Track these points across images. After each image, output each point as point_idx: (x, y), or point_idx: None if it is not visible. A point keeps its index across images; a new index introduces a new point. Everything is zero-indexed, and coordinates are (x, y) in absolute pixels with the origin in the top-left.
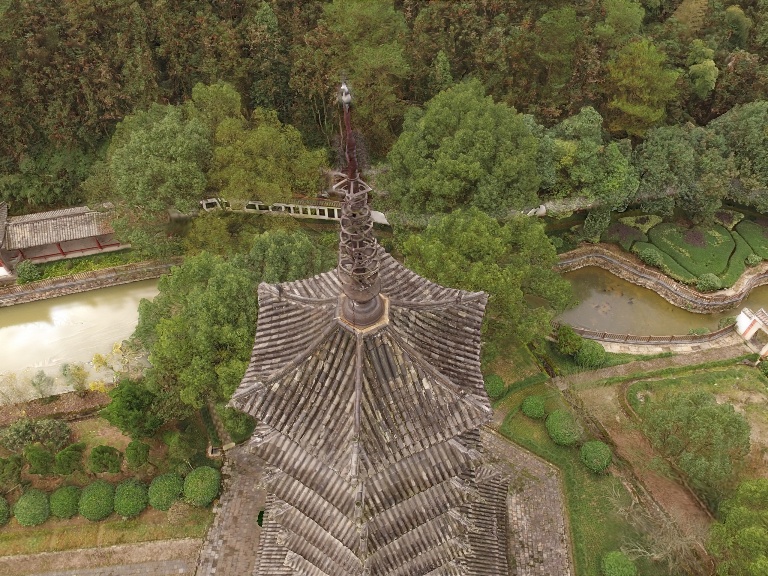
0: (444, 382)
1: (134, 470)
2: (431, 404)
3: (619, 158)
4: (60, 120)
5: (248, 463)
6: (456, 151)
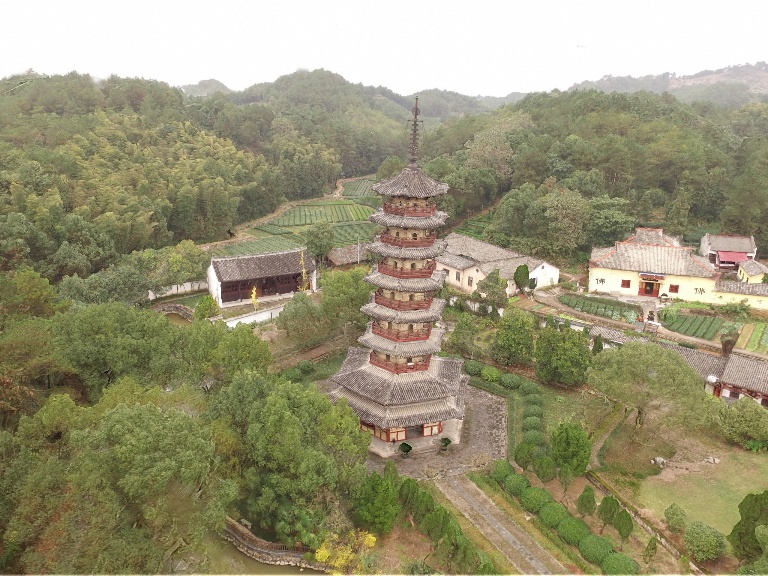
0: None
1: None
2: None
3: None
4: None
5: None
6: None
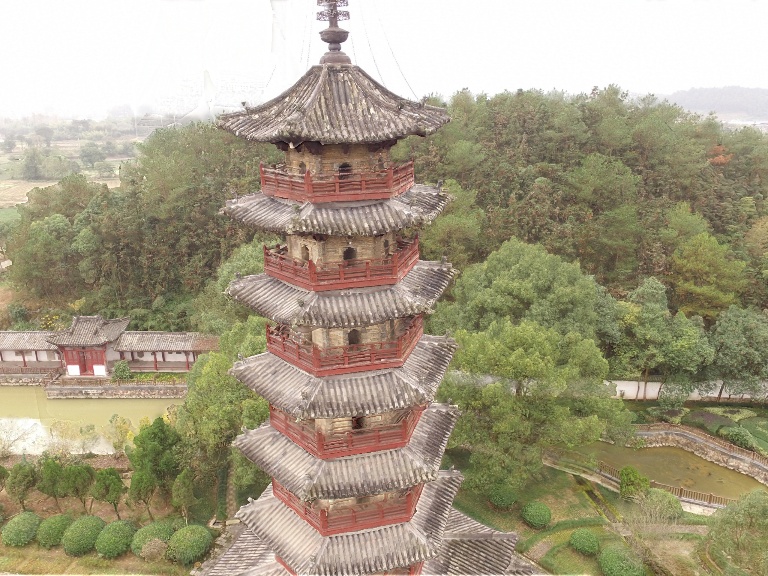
0: (387, 105)
1: (131, 506)
2: (373, 122)
3: (688, 325)
4: (196, 269)
5: None
6: (512, 278)
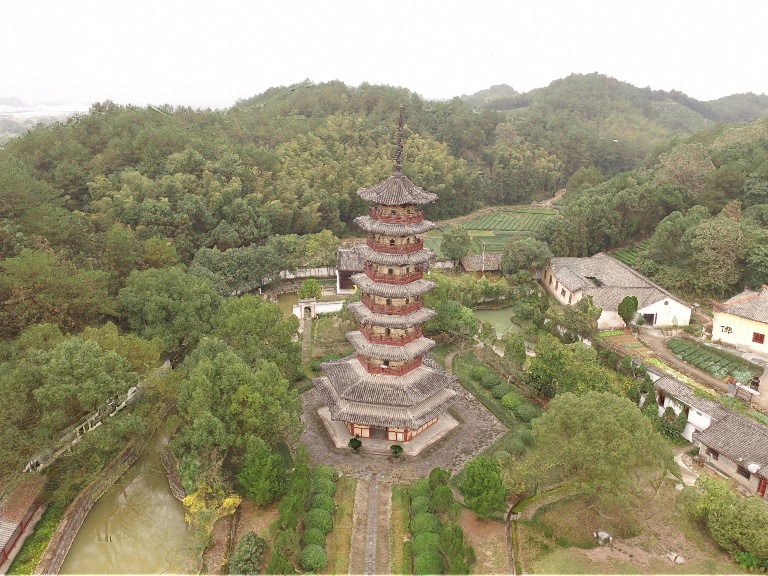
0: None
1: None
2: None
3: None
4: None
5: (311, 463)
6: None
